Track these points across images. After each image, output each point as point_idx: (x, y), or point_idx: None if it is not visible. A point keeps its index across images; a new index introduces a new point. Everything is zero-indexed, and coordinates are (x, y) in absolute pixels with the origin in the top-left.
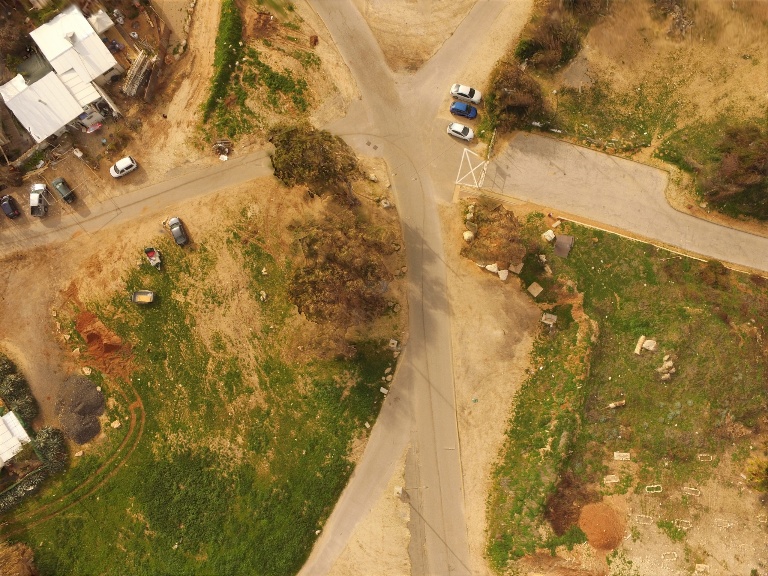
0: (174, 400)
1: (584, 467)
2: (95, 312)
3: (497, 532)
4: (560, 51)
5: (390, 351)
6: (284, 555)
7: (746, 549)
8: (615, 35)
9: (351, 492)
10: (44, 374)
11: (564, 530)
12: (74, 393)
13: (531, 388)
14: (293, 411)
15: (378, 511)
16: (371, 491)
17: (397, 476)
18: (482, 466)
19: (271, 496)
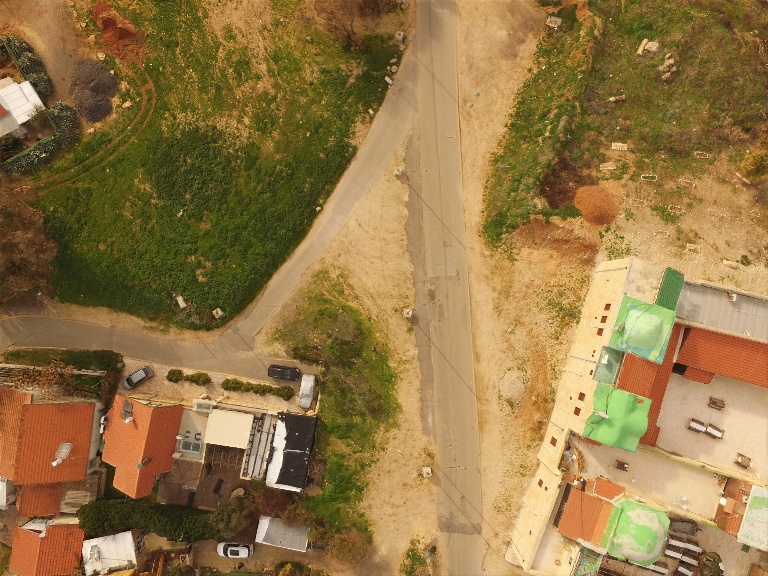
0: (184, 83)
1: (581, 153)
2: (111, 3)
3: (493, 212)
4: None
5: (396, 45)
6: (285, 226)
7: (737, 237)
8: None
9: (352, 174)
10: (60, 57)
11: (559, 205)
12: (88, 71)
13: (533, 86)
14: (299, 96)
15: (378, 192)
16: (372, 173)
17: (398, 160)
18: (481, 155)
19: (274, 172)
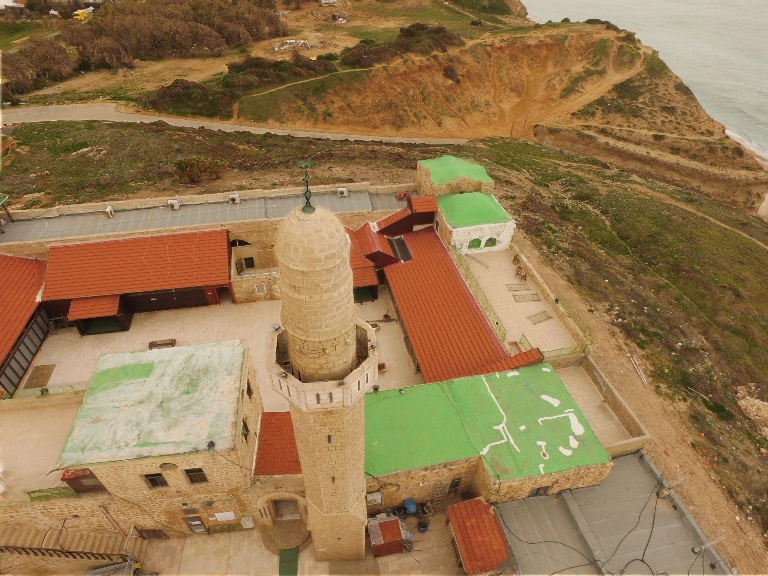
0: None
1: None
2: None
3: None
4: (30, 80)
5: None
6: None
7: None
8: (85, 81)
9: None
10: None
11: None
12: None
13: None
14: None
15: None
16: None
17: None
18: None
19: None
